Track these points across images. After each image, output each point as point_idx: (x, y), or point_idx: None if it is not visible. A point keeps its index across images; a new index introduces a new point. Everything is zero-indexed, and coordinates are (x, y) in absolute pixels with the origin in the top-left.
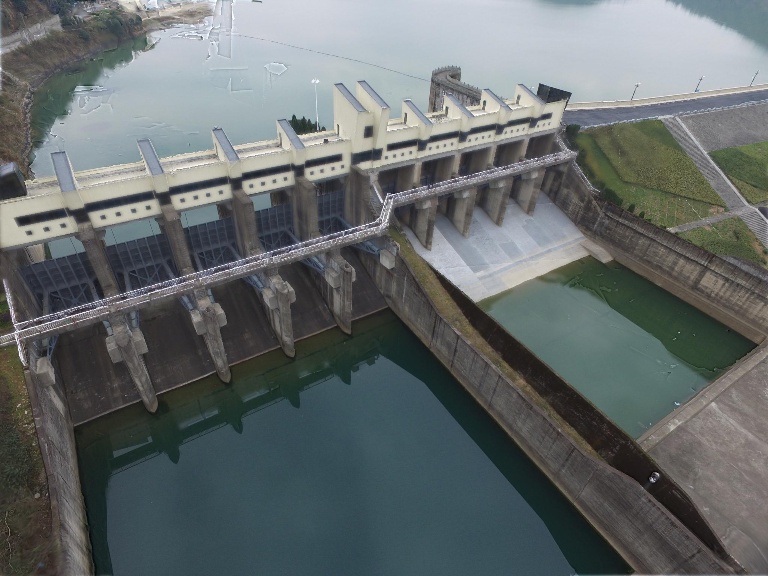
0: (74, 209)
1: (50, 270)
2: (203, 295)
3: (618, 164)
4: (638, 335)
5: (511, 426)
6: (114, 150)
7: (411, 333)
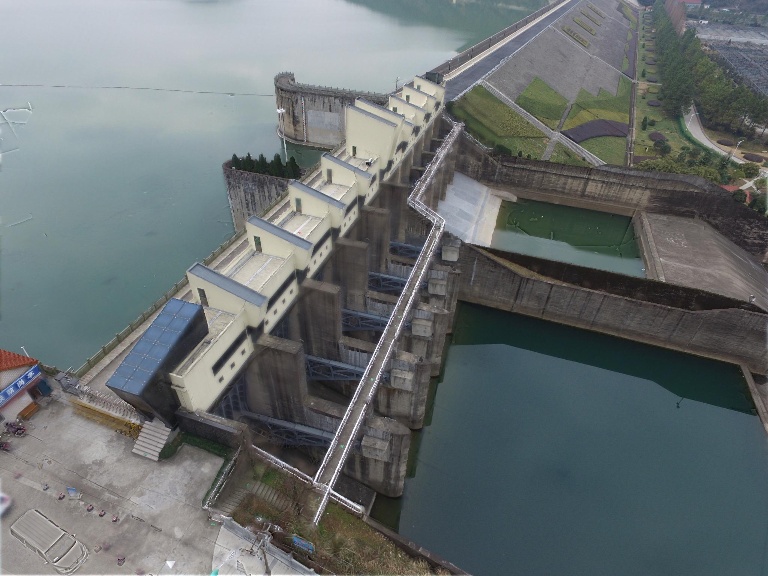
0: None
1: None
2: (398, 351)
3: (488, 125)
4: None
5: (618, 328)
6: None
7: (484, 308)
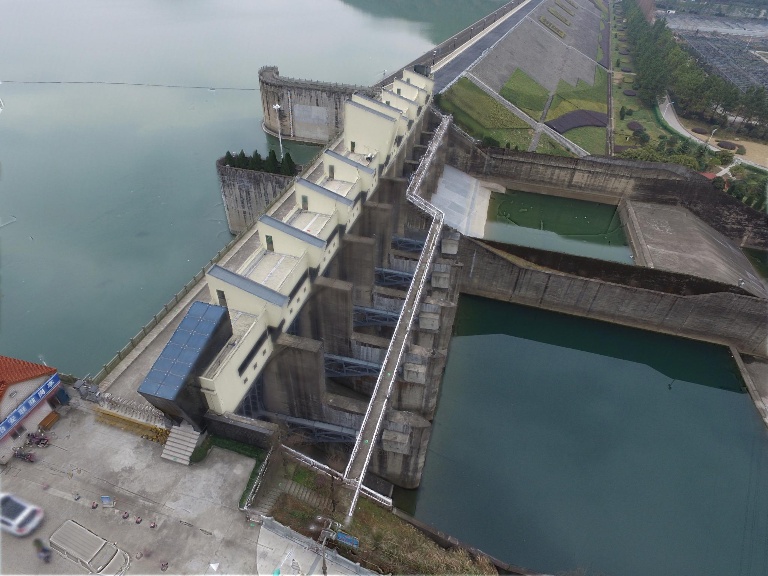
0: None
1: None
2: None
3: (476, 117)
4: None
5: (613, 315)
6: None
7: (483, 299)
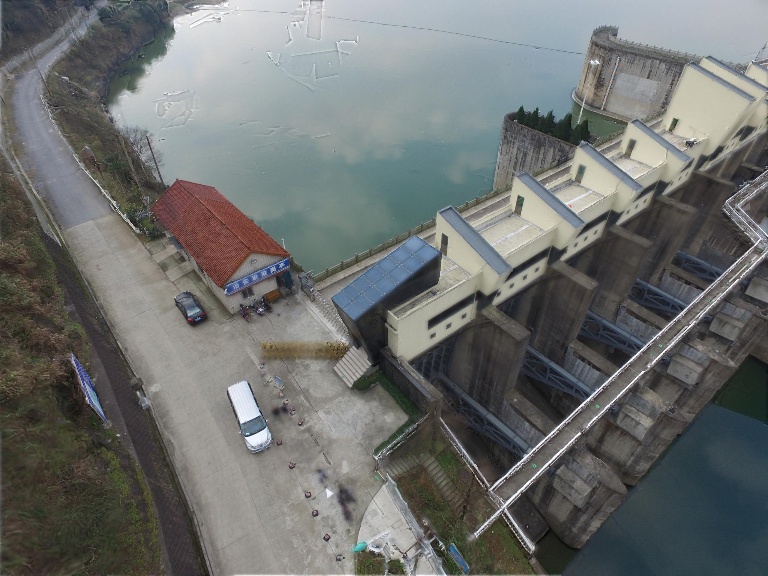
0: (491, 293)
1: None
2: None
3: None
4: None
5: None
6: (252, 168)
7: None
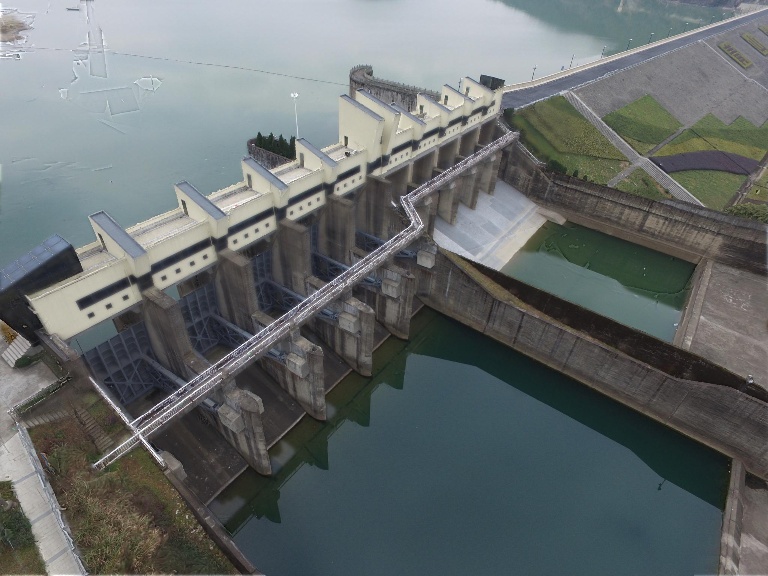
0: (141, 275)
1: (102, 354)
2: (297, 336)
3: (550, 138)
4: (601, 279)
5: (592, 378)
6: (18, 203)
7: (458, 323)
